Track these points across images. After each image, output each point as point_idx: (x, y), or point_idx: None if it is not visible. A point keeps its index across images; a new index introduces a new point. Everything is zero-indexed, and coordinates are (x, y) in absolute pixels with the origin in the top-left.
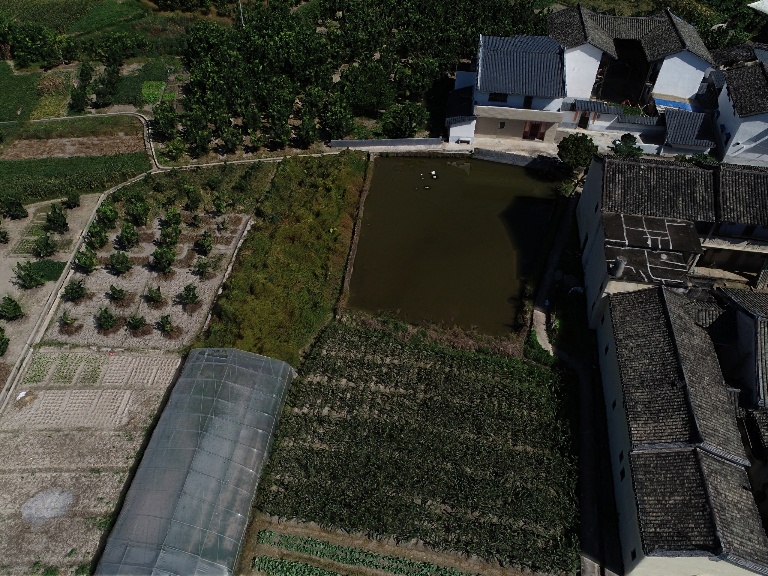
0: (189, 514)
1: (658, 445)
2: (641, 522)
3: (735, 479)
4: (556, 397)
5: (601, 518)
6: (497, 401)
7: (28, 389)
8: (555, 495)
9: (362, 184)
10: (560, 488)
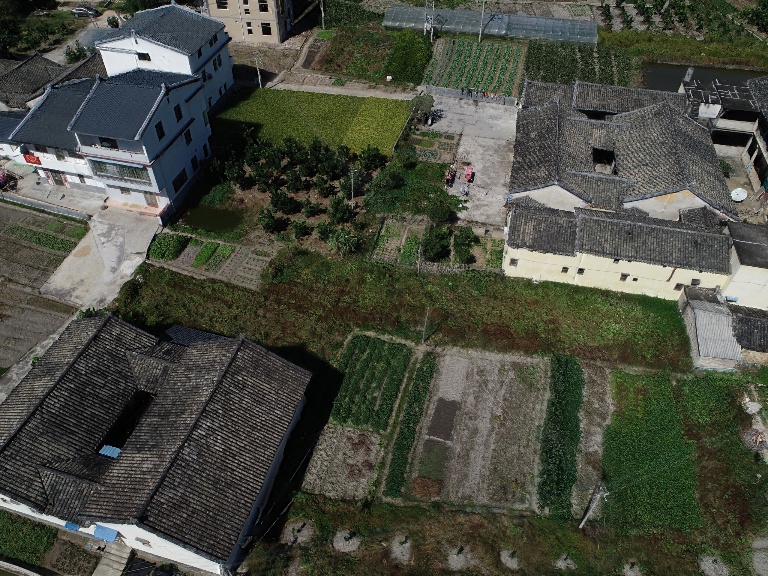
0: (522, 20)
1: None
2: None
3: None
4: None
5: None
6: None
7: (567, 6)
8: None
9: (760, 66)
10: None
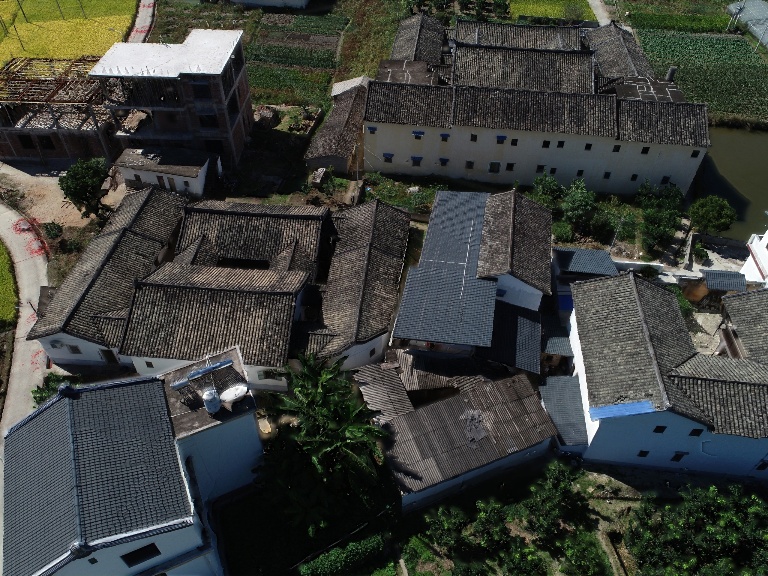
0: None
1: None
2: None
3: None
4: None
5: None
6: None
7: None
8: None
9: None
10: None
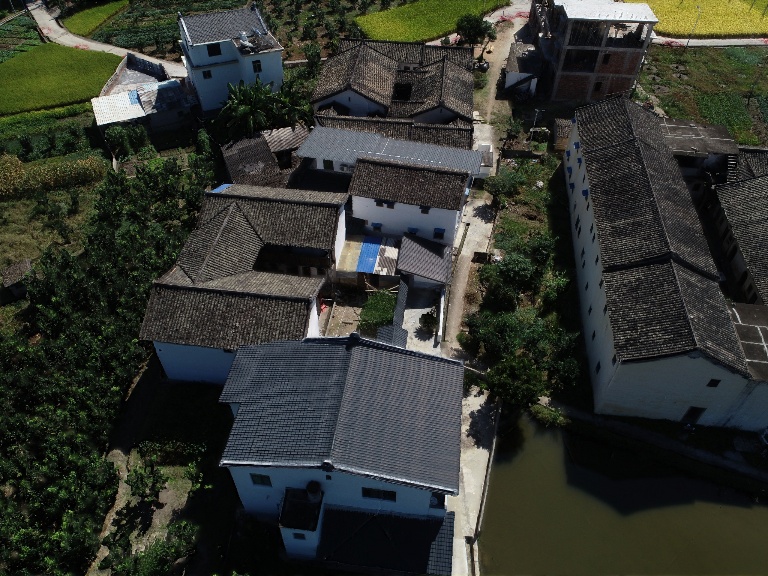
0: None
1: None
2: None
3: None
4: None
5: None
6: None
7: None
8: None
9: None
10: None
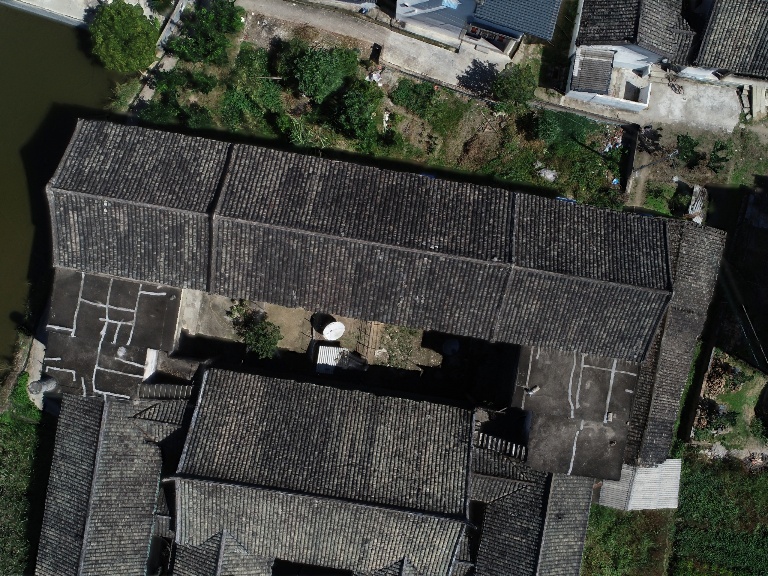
0: None
1: None
2: None
3: None
4: (30, 469)
5: None
6: None
7: None
8: None
9: None
10: None
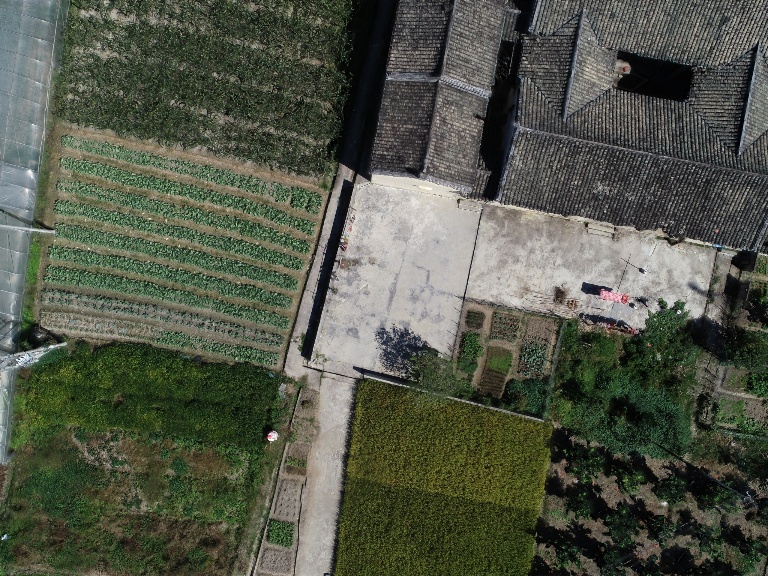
0: None
1: (407, 75)
2: (374, 145)
3: (471, 109)
4: (352, 4)
5: (366, 131)
6: (293, 6)
7: None
8: (331, 109)
9: None
10: (334, 103)
